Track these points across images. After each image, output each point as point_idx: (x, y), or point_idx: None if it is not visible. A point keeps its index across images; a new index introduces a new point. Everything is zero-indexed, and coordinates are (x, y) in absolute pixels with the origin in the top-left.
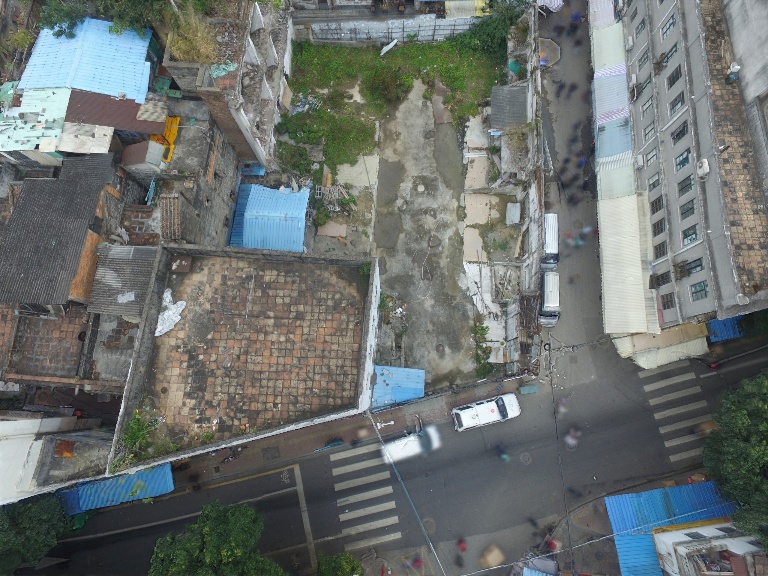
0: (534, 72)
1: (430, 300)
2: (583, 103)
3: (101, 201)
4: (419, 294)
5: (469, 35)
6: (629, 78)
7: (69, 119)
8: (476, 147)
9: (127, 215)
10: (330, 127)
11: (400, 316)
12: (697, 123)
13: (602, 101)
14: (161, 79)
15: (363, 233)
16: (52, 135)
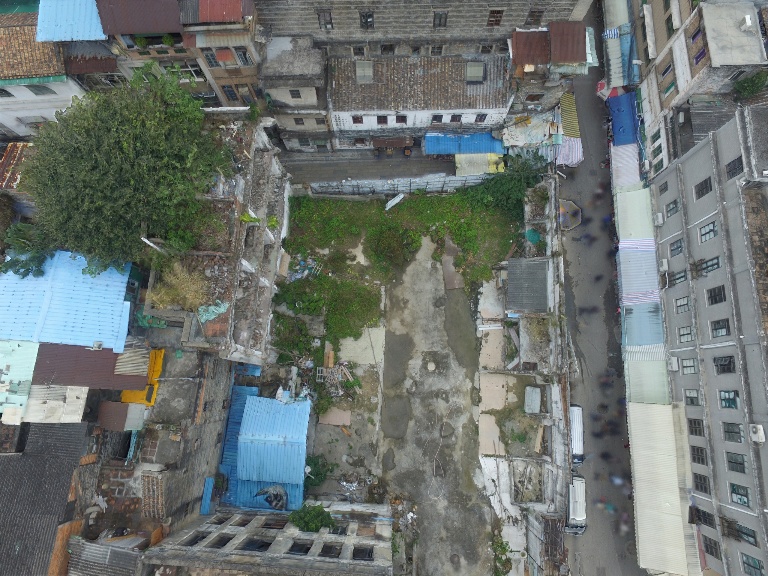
0: (556, 257)
1: (443, 501)
2: (605, 264)
3: (73, 482)
4: (431, 494)
5: (481, 190)
6: (660, 262)
7: (36, 380)
8: (491, 318)
9: (105, 474)
10: (331, 294)
11: (411, 522)
12: (747, 370)
13: (629, 278)
14: (143, 306)
15: (369, 421)
16: (17, 402)
